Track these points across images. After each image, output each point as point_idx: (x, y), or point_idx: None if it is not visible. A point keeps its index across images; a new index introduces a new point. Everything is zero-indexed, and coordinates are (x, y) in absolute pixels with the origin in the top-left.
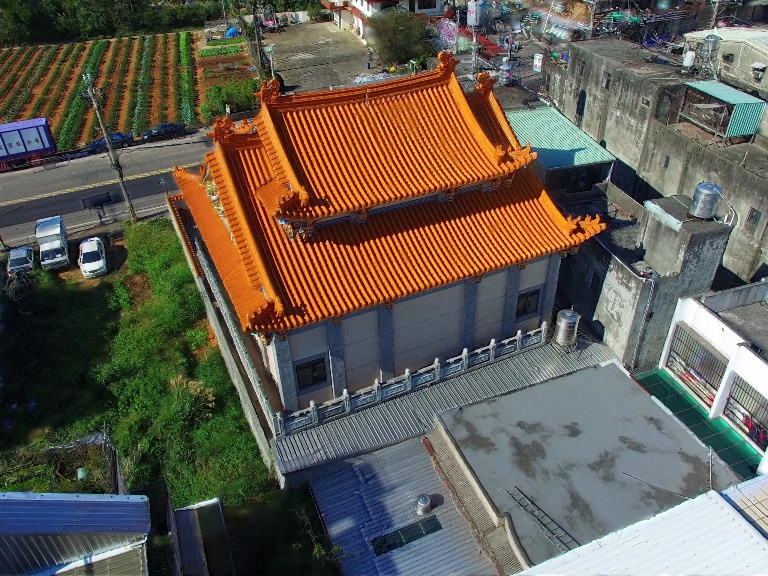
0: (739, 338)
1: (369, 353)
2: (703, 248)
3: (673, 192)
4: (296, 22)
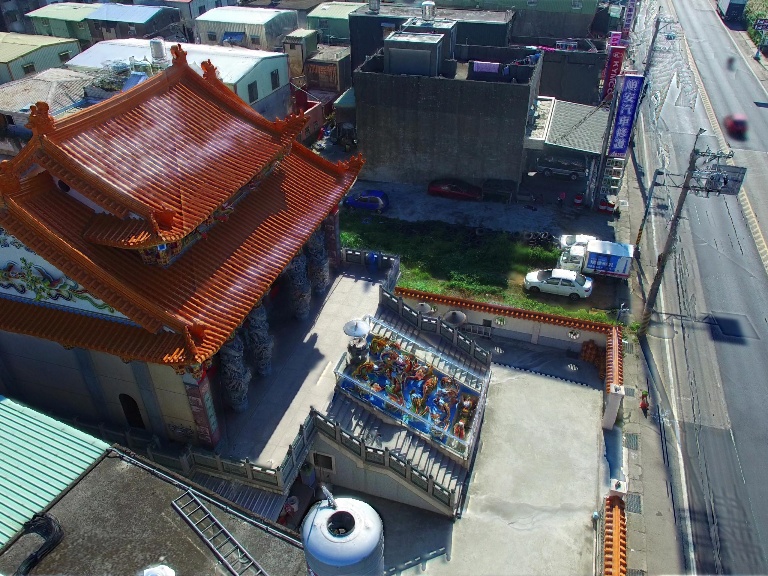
0: None
1: None
2: None
3: None
4: None
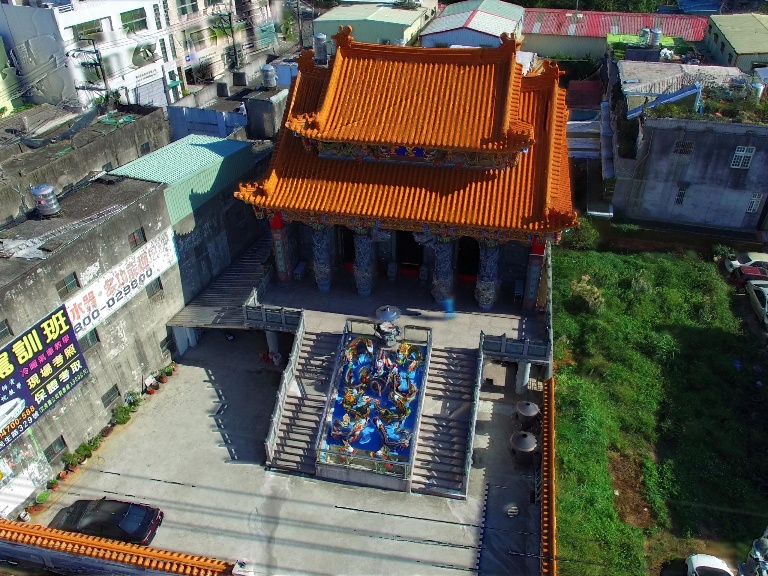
0: None
1: None
2: None
3: None
4: None
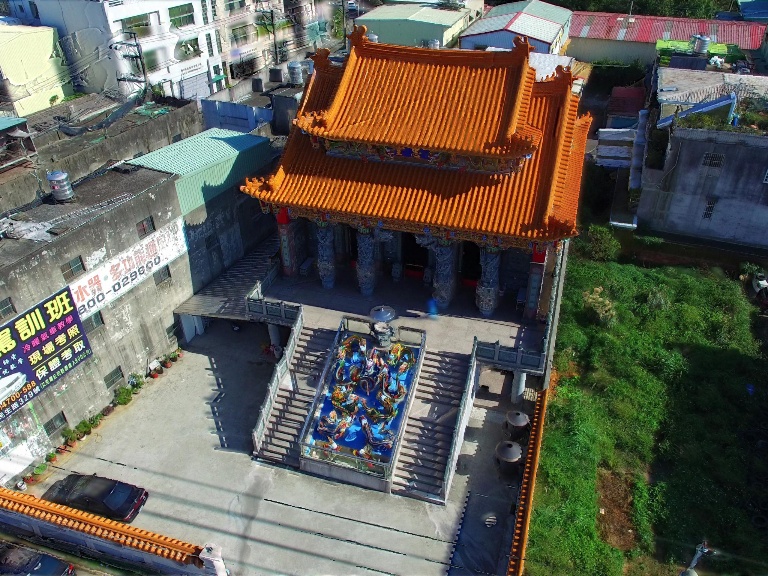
0: None
1: None
2: None
3: None
4: None
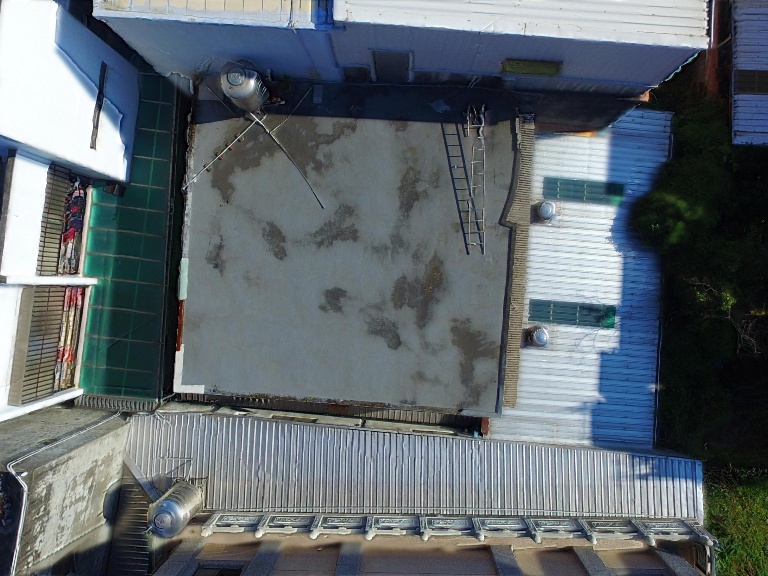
0: None
1: None
2: None
3: None
4: None
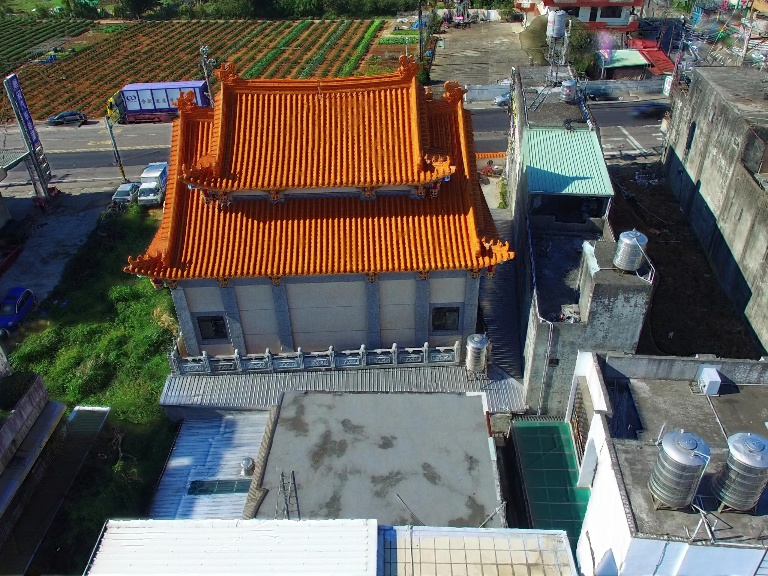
0: (604, 405)
1: (268, 324)
2: (616, 302)
3: (739, 250)
4: (486, 20)
